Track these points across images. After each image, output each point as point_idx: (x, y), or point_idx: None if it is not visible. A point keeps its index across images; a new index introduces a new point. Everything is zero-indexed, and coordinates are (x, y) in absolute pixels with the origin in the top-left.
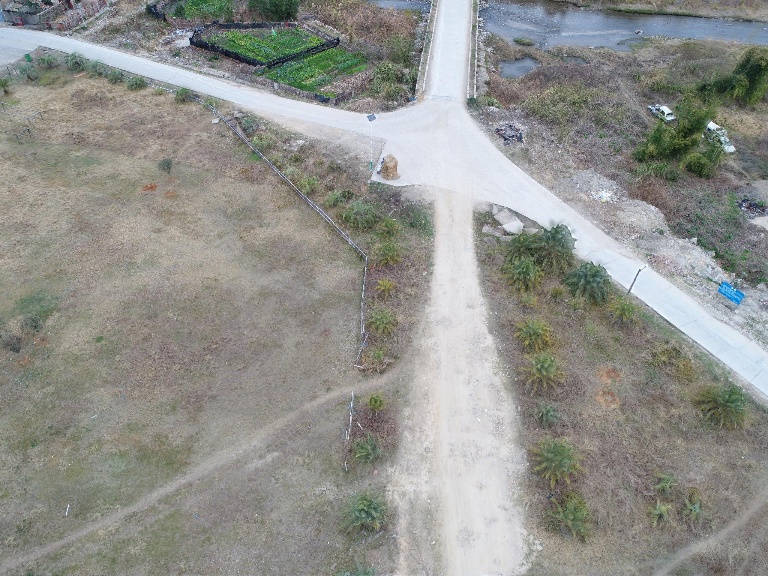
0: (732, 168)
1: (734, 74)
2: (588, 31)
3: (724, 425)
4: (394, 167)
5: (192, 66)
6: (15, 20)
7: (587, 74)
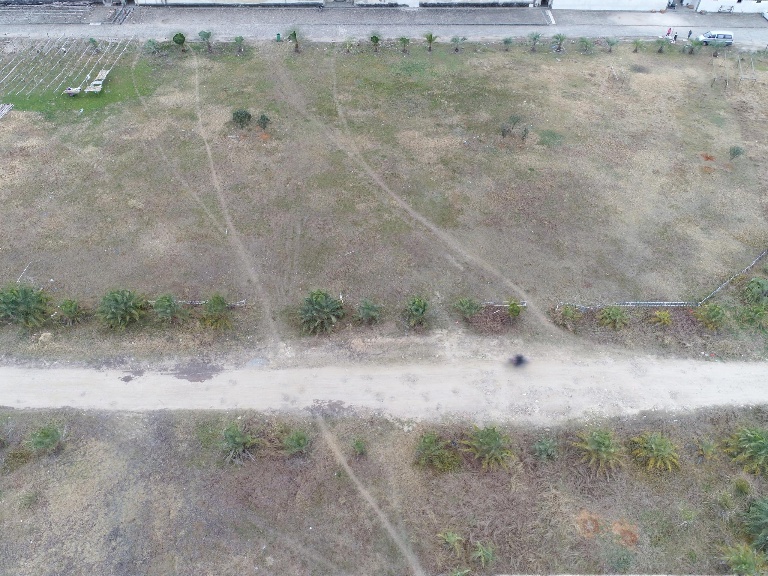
0: None
1: None
2: None
3: None
4: None
5: None
6: None
7: None
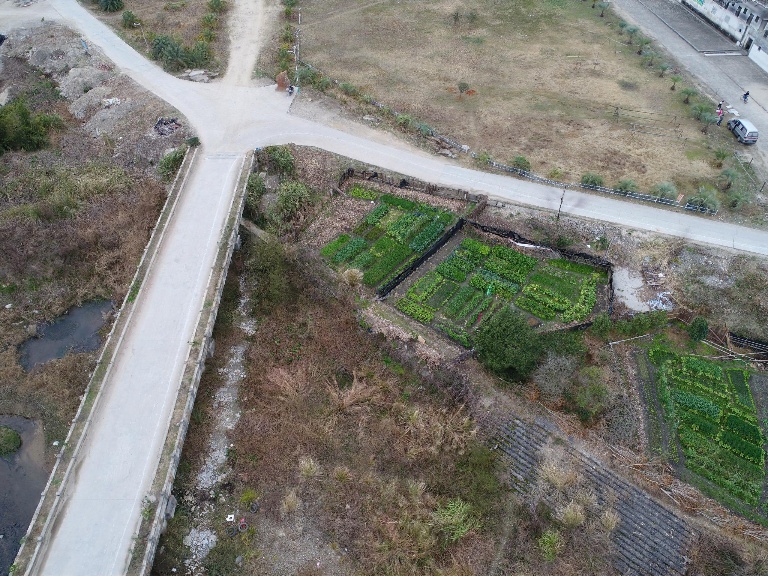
0: None
1: None
2: None
3: None
4: None
5: None
6: None
7: None
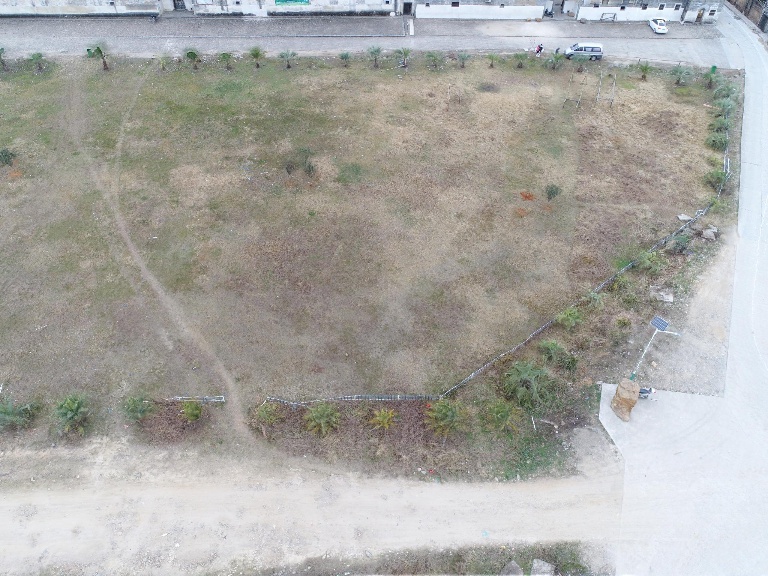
0: None
1: None
2: None
3: None
4: (627, 402)
5: None
6: None
7: None
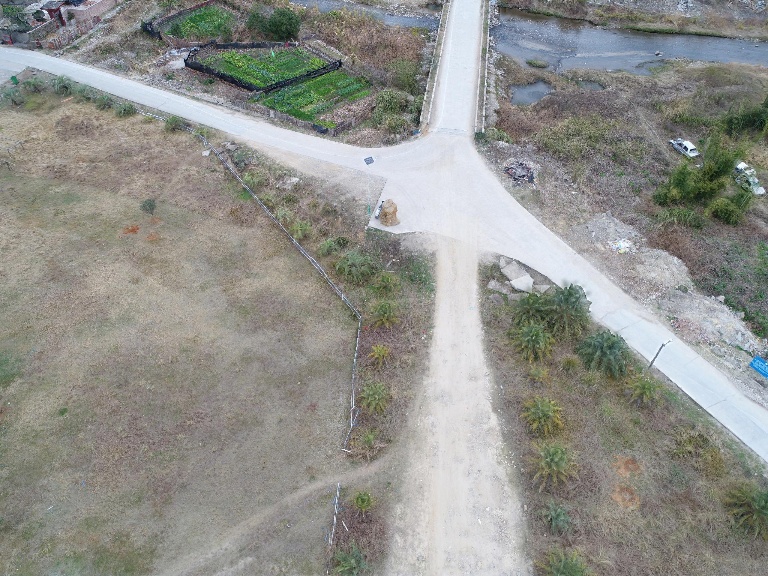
0: (762, 213)
1: (764, 107)
2: (605, 52)
3: (759, 534)
4: (393, 213)
5: (185, 91)
6: (4, 38)
7: (604, 103)
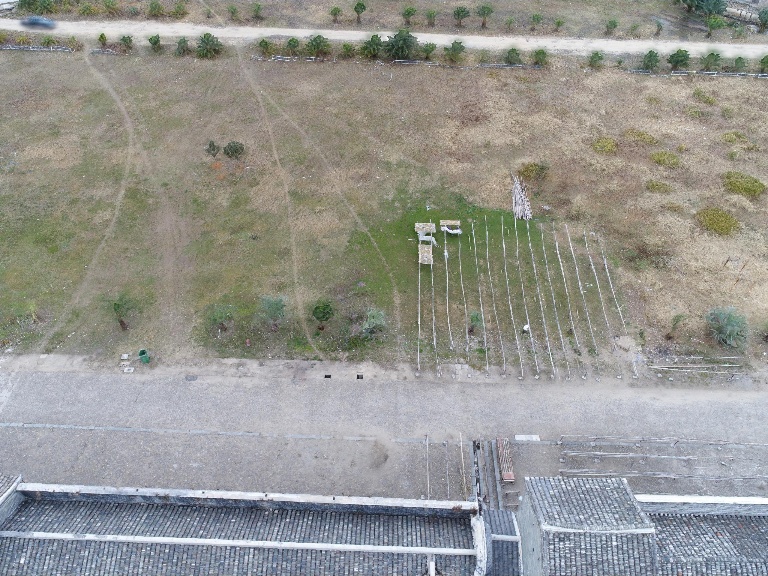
0: None
1: None
2: None
3: None
4: None
5: None
6: None
7: None
